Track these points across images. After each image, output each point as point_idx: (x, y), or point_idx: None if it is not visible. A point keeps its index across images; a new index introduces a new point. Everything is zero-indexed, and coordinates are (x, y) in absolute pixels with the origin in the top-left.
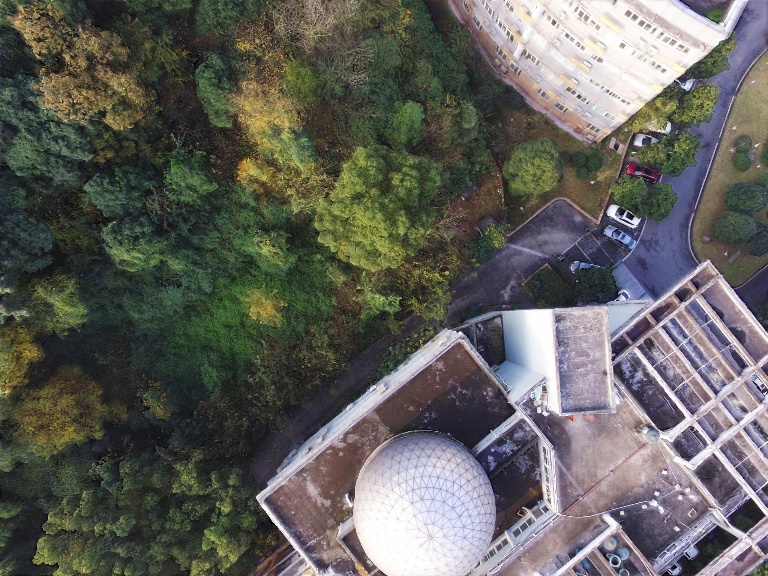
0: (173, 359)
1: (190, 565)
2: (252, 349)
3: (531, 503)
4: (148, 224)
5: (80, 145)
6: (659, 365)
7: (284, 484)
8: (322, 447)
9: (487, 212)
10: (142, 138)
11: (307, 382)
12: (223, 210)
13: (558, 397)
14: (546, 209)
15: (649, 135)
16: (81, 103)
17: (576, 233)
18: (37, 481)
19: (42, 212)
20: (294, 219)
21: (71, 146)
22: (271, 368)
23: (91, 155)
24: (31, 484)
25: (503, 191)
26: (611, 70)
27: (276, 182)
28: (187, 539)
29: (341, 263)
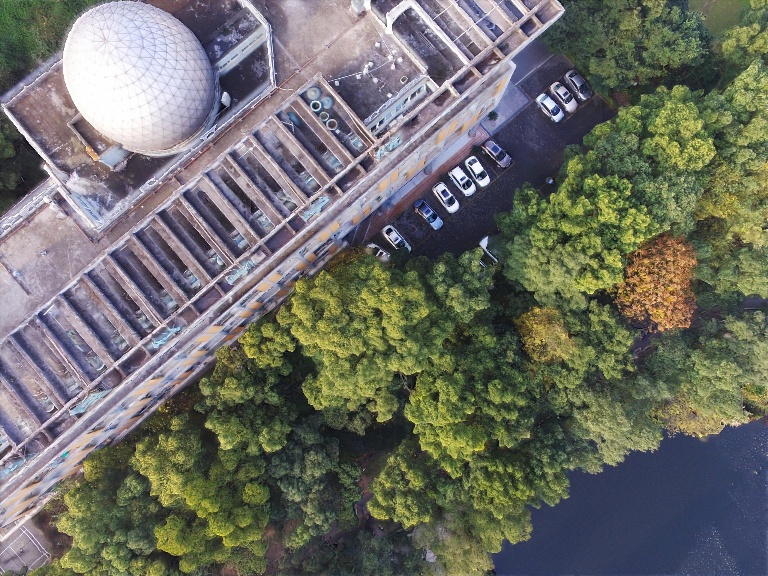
0: None
1: None
2: None
3: None
4: None
5: None
6: None
7: (30, 96)
8: None
9: None
10: None
11: None
12: None
13: None
14: None
15: None
16: None
17: None
18: None
19: None
20: None
21: None
22: (50, 38)
23: None
24: None
25: None
26: None
27: None
28: None
29: None
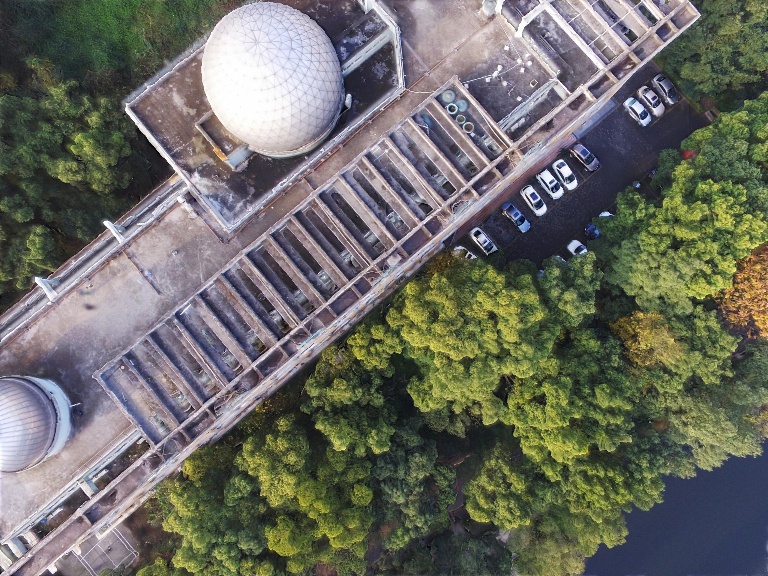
0: (66, 45)
1: None
2: None
3: None
4: None
5: None
6: None
7: (151, 95)
8: None
9: None
10: None
11: None
12: None
13: None
14: None
15: None
16: None
17: None
18: None
19: None
20: None
21: None
22: (156, 38)
23: None
24: None
25: None
26: None
27: None
28: (61, 155)
29: None
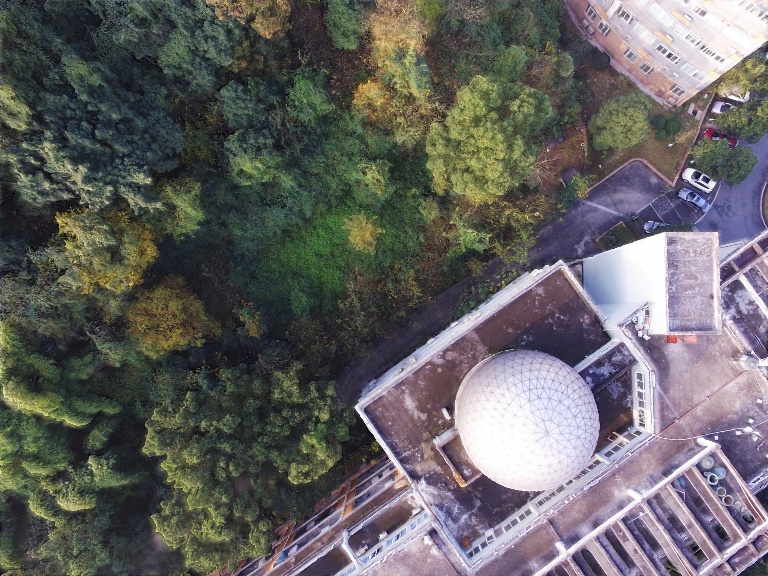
0: (265, 282)
1: (289, 467)
2: (339, 279)
3: (622, 429)
4: (270, 136)
5: (224, 48)
6: (763, 294)
7: (383, 395)
8: (422, 361)
9: (570, 165)
10: (270, 54)
11: (392, 313)
12: (330, 136)
13: (666, 316)
14: (623, 169)
15: (728, 102)
16: (239, 1)
17: (651, 194)
18: (134, 386)
19: (174, 116)
20: (395, 151)
21: (217, 48)
22: (363, 294)
23: (231, 60)
24: (129, 388)
25: (587, 145)
26: (712, 24)
27: (385, 110)
28: (285, 444)
29: (436, 197)
